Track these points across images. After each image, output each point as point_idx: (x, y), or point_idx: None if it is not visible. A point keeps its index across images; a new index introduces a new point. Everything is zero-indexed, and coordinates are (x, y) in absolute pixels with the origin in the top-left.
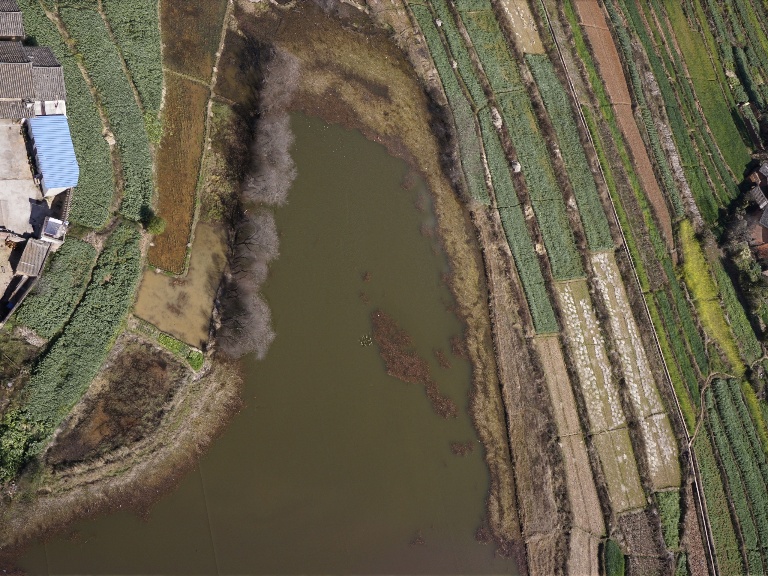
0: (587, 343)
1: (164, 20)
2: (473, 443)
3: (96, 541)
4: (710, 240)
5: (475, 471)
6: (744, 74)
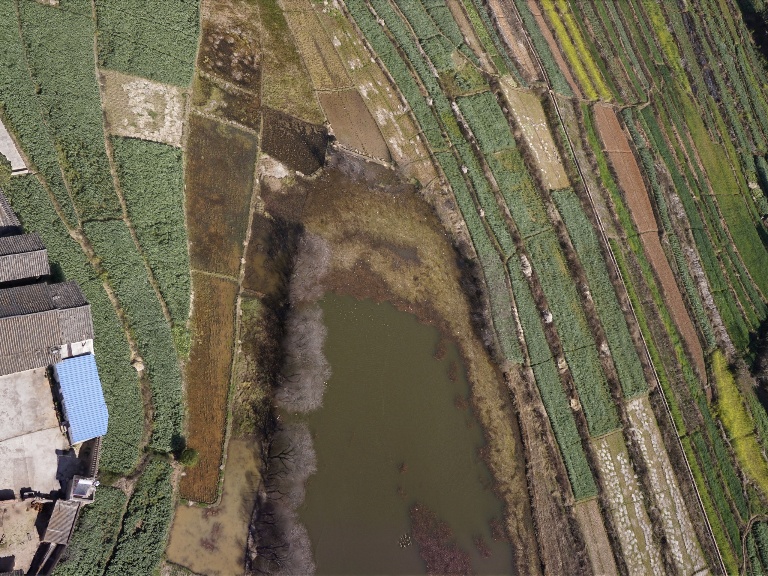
0: (626, 502)
1: (190, 214)
2: None
3: None
4: (743, 370)
5: None
6: (767, 184)
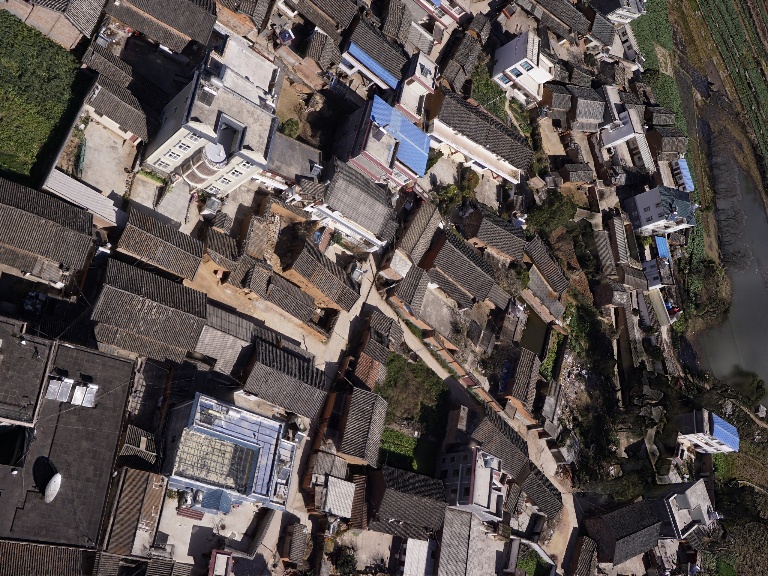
0: None
1: None
2: None
3: (713, 339)
4: None
5: None
6: None
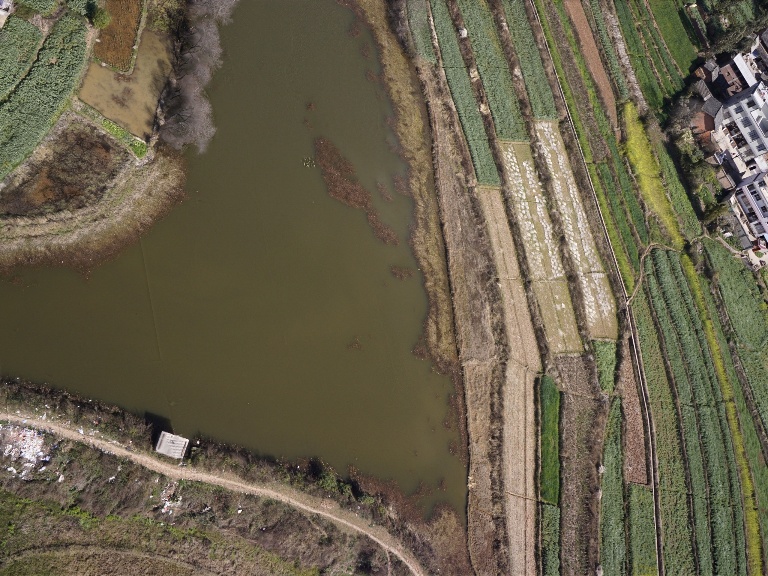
0: (529, 200)
1: None
2: (413, 270)
3: (38, 288)
4: (653, 123)
5: (414, 295)
6: None
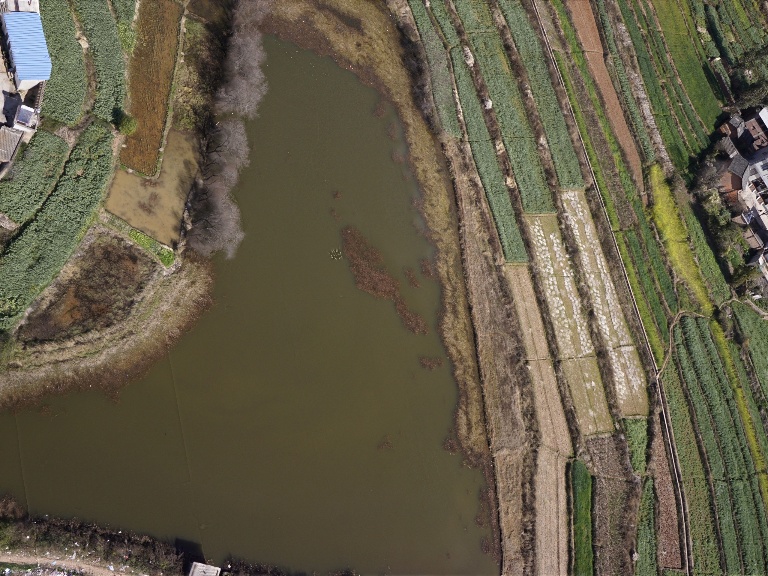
0: (557, 274)
1: None
2: (442, 359)
3: (66, 416)
4: (680, 185)
5: (444, 386)
6: (715, 30)
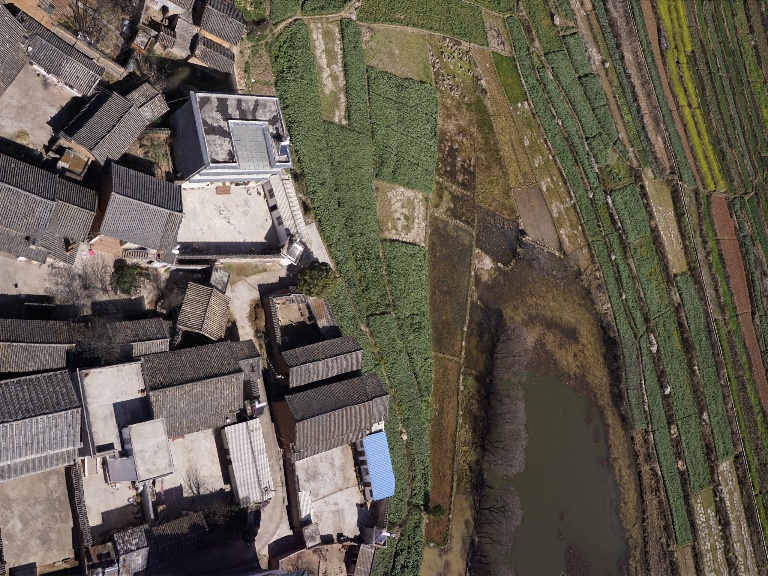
0: (712, 549)
1: (430, 305)
2: None
3: None
4: None
5: None
6: None
